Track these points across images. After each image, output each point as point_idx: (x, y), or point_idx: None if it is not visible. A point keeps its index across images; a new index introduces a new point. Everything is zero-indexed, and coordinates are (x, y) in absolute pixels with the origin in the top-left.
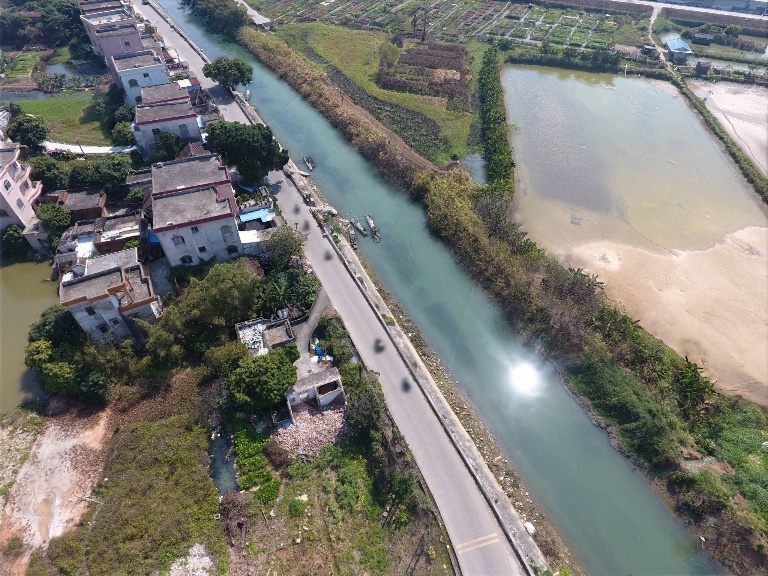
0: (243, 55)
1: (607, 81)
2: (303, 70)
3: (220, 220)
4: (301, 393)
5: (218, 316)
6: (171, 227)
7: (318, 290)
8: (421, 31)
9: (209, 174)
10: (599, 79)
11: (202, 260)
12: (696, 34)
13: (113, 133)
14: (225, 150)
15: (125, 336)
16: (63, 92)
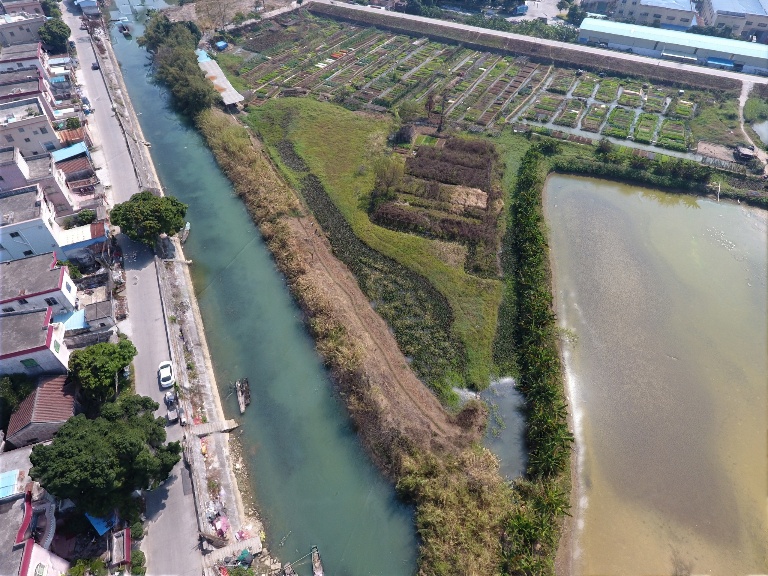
0: (203, 148)
1: (689, 201)
2: (267, 194)
3: None
4: None
5: None
6: None
7: None
8: (438, 114)
9: None
10: None
11: None
12: None
13: None
14: None
15: None
16: None
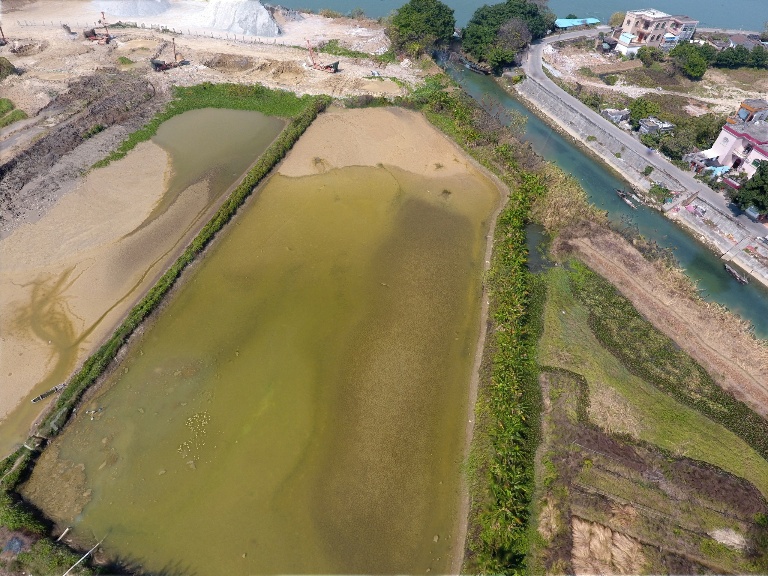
0: None
1: None
2: None
3: None
4: None
5: None
6: None
7: None
8: None
9: None
10: None
11: None
12: None
13: None
14: None
15: None
16: None
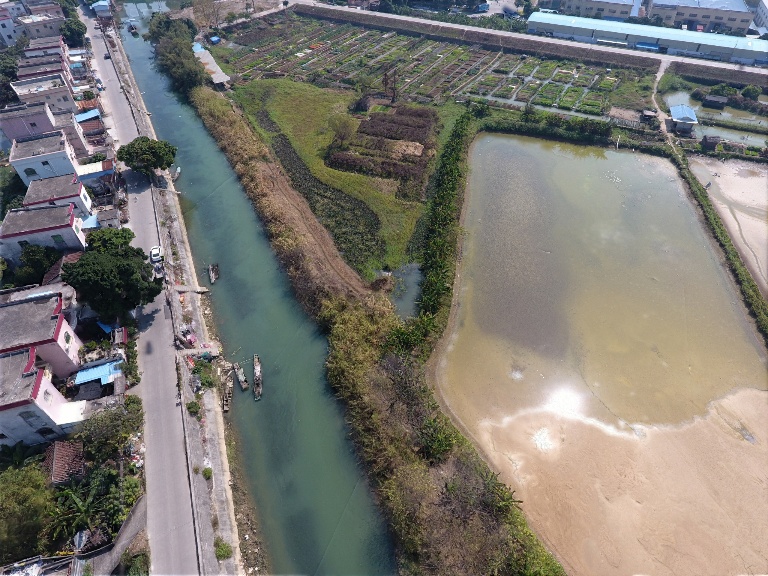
0: (195, 118)
1: (597, 153)
2: (243, 145)
3: (14, 408)
4: None
5: None
6: None
7: (135, 502)
8: (394, 90)
9: (36, 326)
10: (588, 150)
11: (5, 446)
12: (707, 96)
13: None
14: None
15: None
16: None
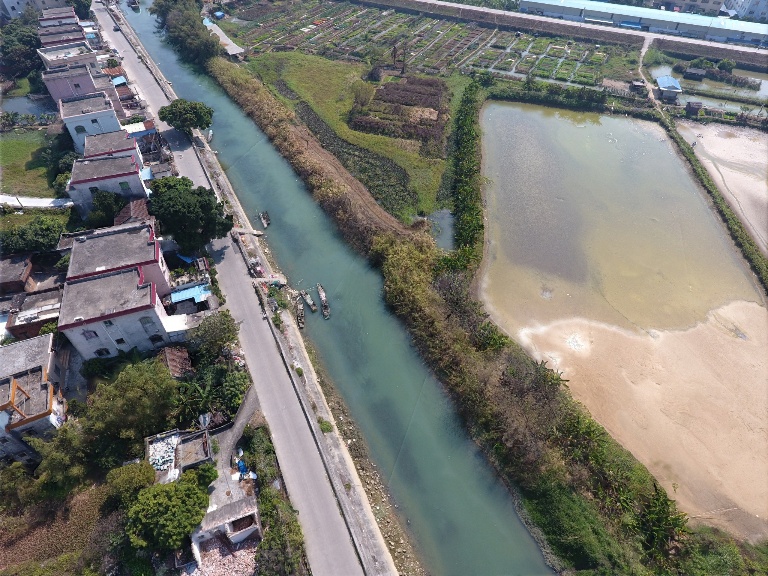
0: (213, 87)
1: (593, 119)
2: (270, 109)
3: (137, 312)
4: (210, 530)
5: (127, 428)
6: (79, 323)
7: (247, 390)
8: (401, 62)
9: (136, 251)
10: (585, 117)
11: (121, 351)
12: (688, 69)
13: (54, 185)
14: (160, 219)
15: (19, 452)
16: (15, 131)
